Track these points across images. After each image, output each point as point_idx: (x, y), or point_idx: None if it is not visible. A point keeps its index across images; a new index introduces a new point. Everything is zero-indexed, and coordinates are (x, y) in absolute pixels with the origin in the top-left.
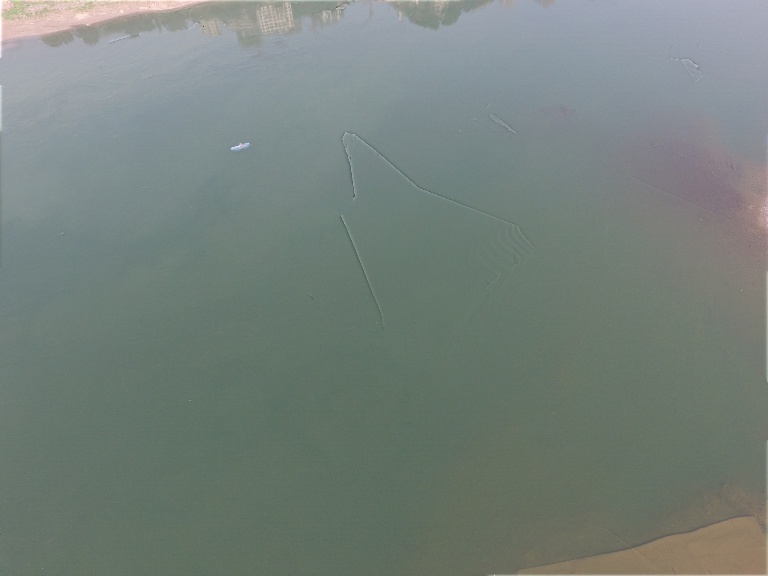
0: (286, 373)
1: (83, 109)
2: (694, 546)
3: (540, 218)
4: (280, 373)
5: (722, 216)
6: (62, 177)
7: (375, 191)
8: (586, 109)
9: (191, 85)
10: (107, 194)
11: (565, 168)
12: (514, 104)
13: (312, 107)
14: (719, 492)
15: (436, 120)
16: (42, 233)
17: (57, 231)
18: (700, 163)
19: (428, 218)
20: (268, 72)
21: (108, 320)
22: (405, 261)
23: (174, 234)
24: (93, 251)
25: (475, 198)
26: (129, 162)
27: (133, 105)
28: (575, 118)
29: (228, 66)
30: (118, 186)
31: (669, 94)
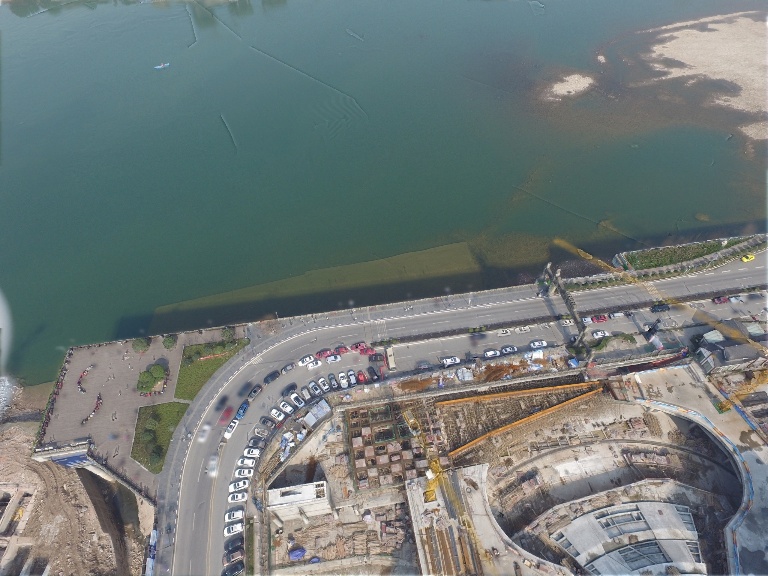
0: (165, 172)
1: (42, 49)
2: (422, 256)
3: (385, 105)
4: (161, 172)
5: (515, 95)
6: (23, 91)
7: (213, 41)
8: (437, 33)
9: (130, 30)
10: (57, 99)
11: (415, 75)
12: (384, 33)
13: None
14: (449, 233)
15: (321, 46)
16: (6, 123)
17: (18, 122)
18: (513, 64)
19: (261, 69)
20: None
21: (52, 167)
22: (244, 96)
23: (105, 119)
24: (44, 131)
25: None
26: (75, 80)
27: (82, 45)
28: (428, 40)
29: (162, 17)
30: (66, 94)
31: (510, 23)
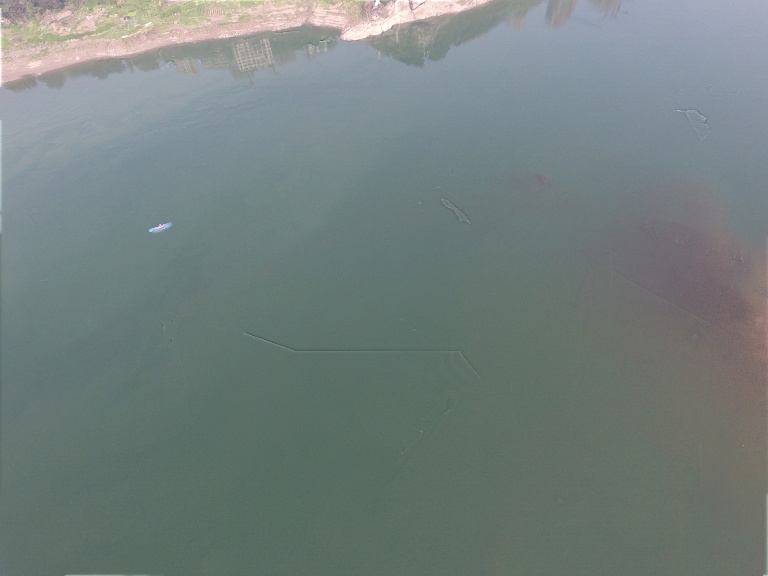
0: None
1: (9, 175)
2: None
3: (499, 324)
4: None
5: (723, 330)
6: None
7: (218, 372)
8: (566, 179)
9: (129, 146)
10: (4, 287)
11: (537, 253)
12: (484, 171)
13: (261, 170)
14: None
15: (392, 191)
16: None
17: None
18: (699, 253)
19: (311, 384)
20: (218, 129)
21: None
22: (276, 444)
23: (62, 345)
24: None
25: (420, 299)
26: (39, 245)
27: (63, 171)
28: (553, 190)
29: (175, 122)
30: (19, 276)
31: (668, 157)
